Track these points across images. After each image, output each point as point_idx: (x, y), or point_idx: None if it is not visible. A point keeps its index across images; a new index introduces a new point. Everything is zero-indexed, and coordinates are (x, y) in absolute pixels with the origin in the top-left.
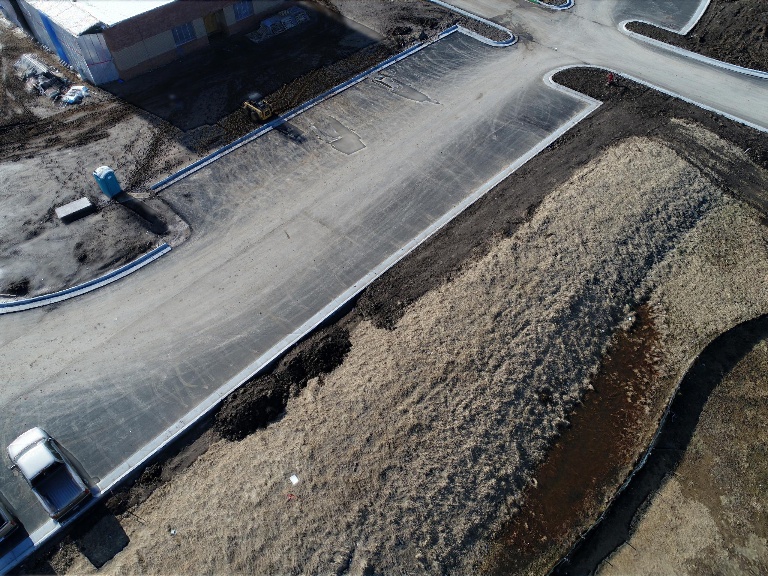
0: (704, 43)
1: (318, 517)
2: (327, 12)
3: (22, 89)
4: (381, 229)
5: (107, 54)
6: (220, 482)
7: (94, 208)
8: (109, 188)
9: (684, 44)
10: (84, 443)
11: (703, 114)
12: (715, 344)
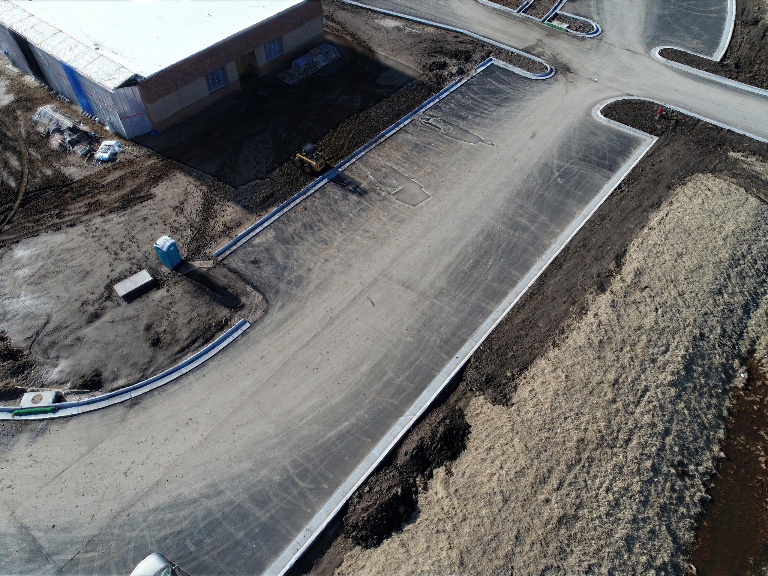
0: (740, 69)
1: None
2: (356, 47)
3: (47, 146)
4: (468, 290)
5: (141, 106)
6: None
7: (155, 282)
8: (170, 259)
9: (721, 71)
10: (206, 564)
11: (758, 146)
12: None
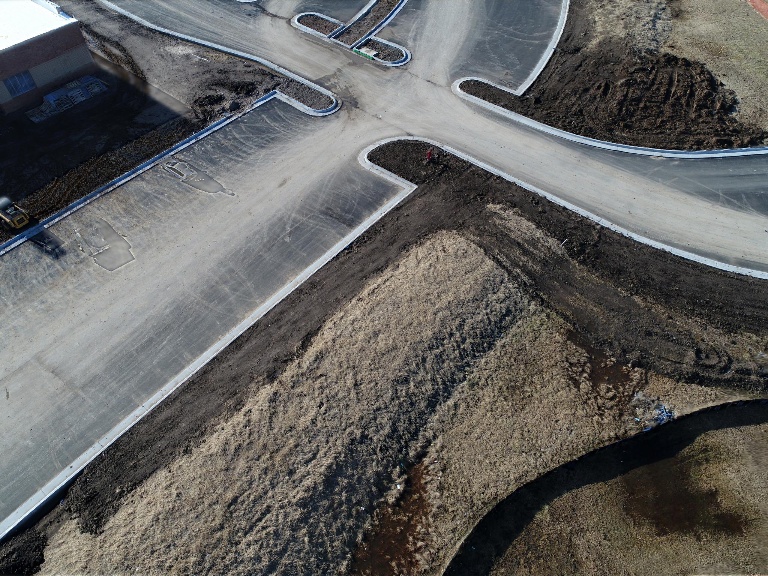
0: (539, 105)
1: None
2: (130, 79)
3: None
4: (124, 377)
5: None
6: None
7: None
8: None
9: (518, 107)
10: None
11: (523, 197)
12: (491, 515)
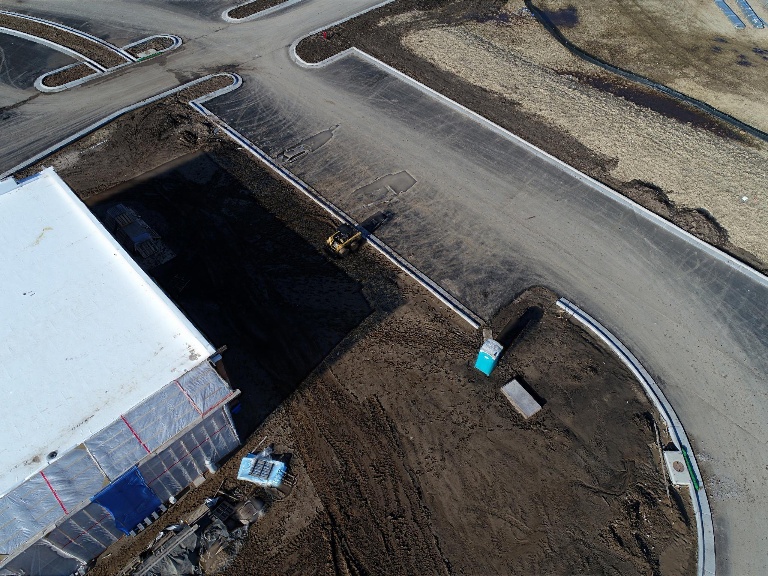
0: None
1: (761, 187)
2: (114, 193)
3: None
4: (516, 164)
5: None
6: (761, 234)
7: None
8: None
9: (275, 1)
10: None
11: (374, 14)
12: None
